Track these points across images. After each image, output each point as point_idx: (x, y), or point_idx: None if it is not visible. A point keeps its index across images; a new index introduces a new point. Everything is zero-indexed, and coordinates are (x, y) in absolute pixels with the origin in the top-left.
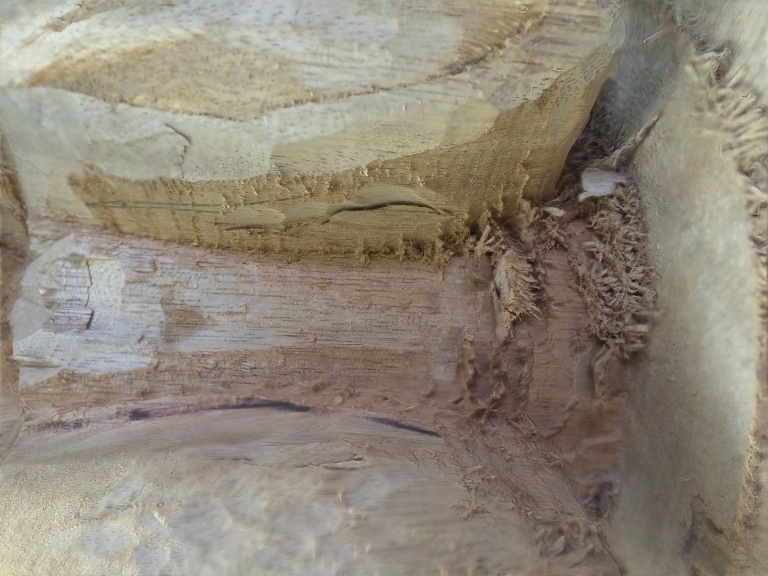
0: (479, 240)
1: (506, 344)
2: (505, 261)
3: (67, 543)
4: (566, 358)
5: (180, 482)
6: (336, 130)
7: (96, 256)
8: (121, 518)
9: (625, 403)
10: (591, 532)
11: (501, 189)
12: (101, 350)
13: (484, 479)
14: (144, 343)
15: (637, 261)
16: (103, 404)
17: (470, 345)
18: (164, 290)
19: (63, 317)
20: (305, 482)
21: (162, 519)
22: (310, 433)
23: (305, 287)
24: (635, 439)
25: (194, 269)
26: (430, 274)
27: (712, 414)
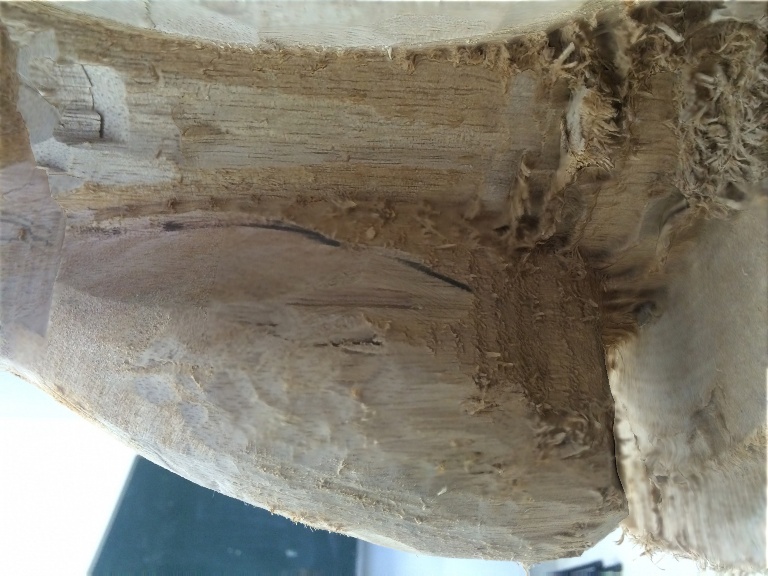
0: (557, 58)
1: (567, 185)
2: (582, 104)
3: (123, 383)
4: (637, 201)
5: (211, 347)
6: (341, 18)
7: (86, 62)
8: (164, 372)
9: (693, 247)
10: (595, 427)
11: (596, 12)
12: (120, 163)
13: (501, 367)
14: (162, 159)
15: (760, 123)
16: (136, 214)
17: (525, 181)
18: (172, 100)
19: (72, 121)
20: (324, 365)
21: (198, 383)
22: (336, 288)
23: (334, 101)
24: (690, 286)
25: (201, 79)
26: (491, 83)
27: (765, 343)
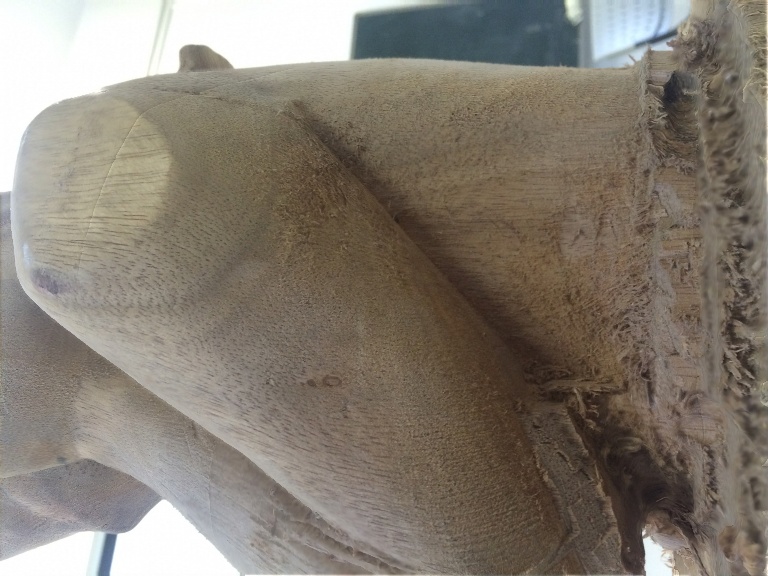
0: None
1: None
2: None
3: None
4: None
5: None
6: None
7: None
8: None
9: None
10: None
11: None
12: None
13: None
14: None
15: None
16: None
17: None
18: None
19: None
20: None
21: None
22: None
23: None
24: None
25: None
26: None
27: None
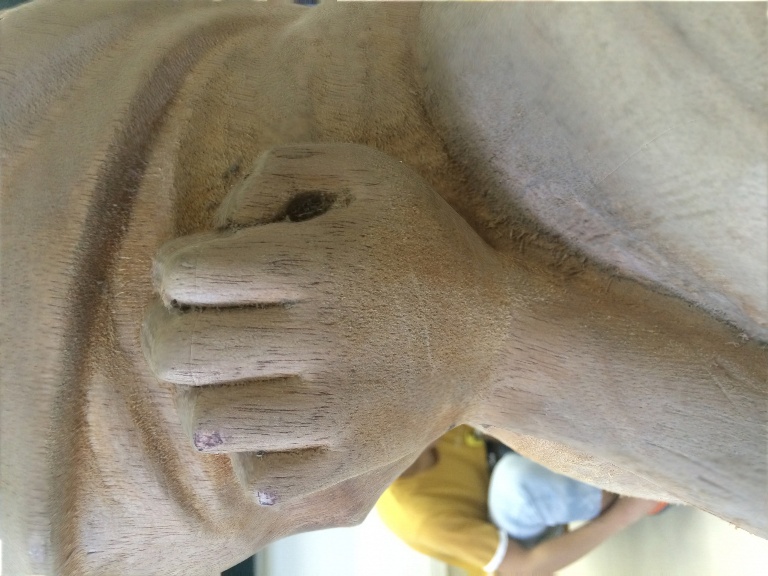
0: None
1: None
2: None
3: None
4: None
5: None
6: None
7: None
8: (593, 468)
9: None
10: None
11: None
12: None
13: None
14: None
15: None
16: None
17: None
18: None
19: None
20: None
21: (611, 476)
22: None
23: None
24: None
25: None
26: None
27: None
